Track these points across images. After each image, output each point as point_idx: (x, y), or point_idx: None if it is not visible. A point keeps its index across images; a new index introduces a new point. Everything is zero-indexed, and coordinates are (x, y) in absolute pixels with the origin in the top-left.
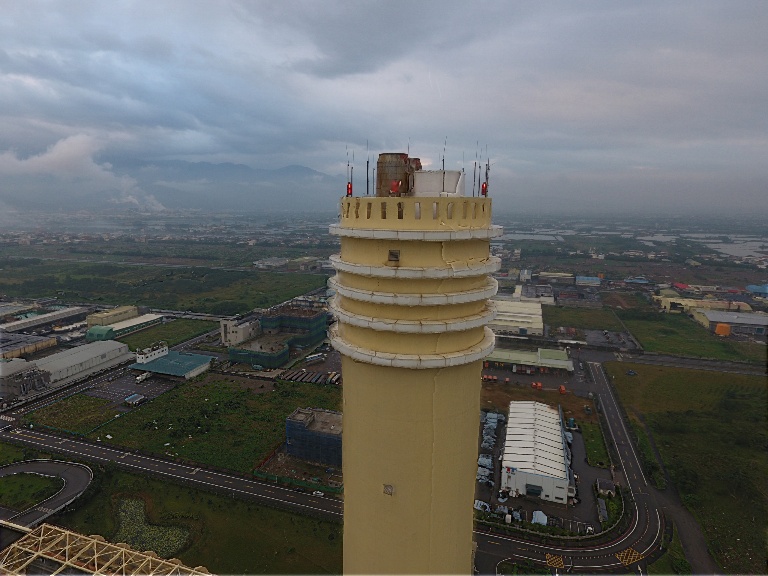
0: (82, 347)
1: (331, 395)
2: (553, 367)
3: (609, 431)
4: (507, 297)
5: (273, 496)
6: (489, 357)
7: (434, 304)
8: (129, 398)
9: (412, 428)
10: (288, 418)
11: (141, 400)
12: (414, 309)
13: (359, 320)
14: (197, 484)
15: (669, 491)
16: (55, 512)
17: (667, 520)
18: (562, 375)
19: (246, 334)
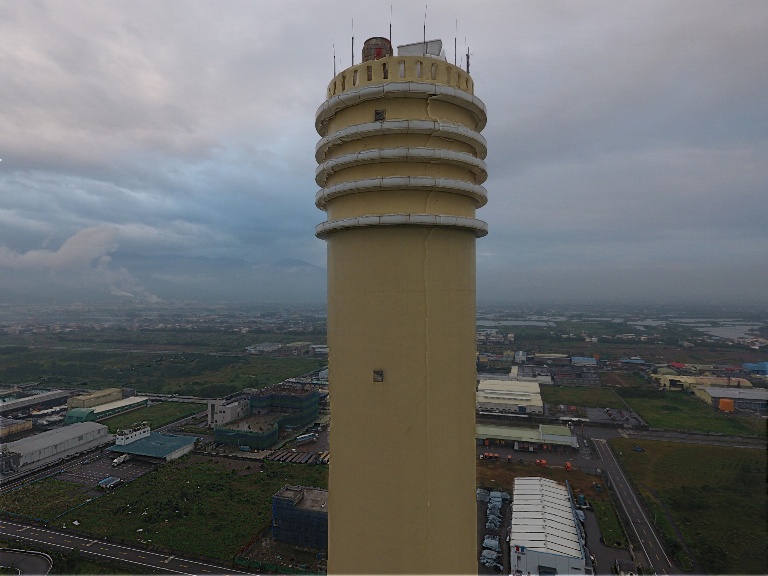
0: (59, 429)
1: (322, 475)
2: (556, 444)
3: (623, 509)
4: (503, 377)
5: None
6: (489, 434)
7: (422, 157)
8: (103, 481)
9: (403, 299)
10: (275, 495)
11: (116, 483)
12: (401, 166)
13: (346, 185)
14: (170, 574)
15: (697, 572)
16: None
17: None
18: (567, 452)
19: (234, 414)
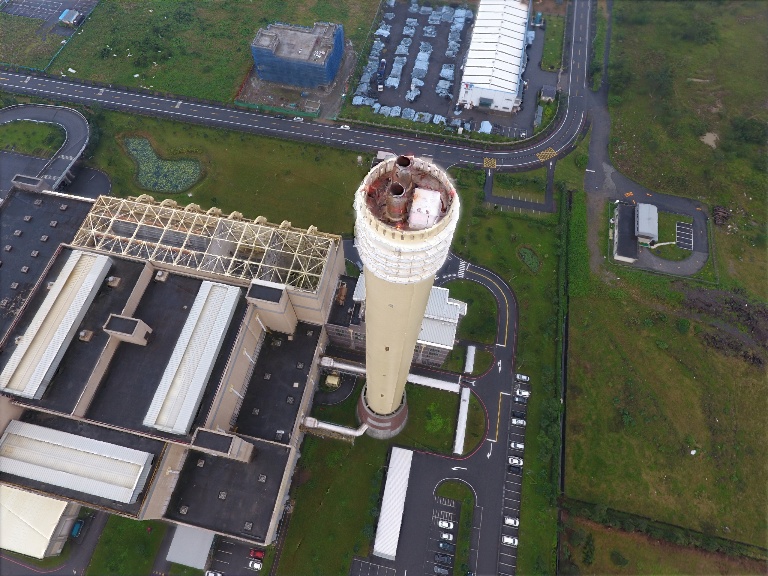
0: None
1: None
2: None
3: (572, 25)
4: None
5: (259, 125)
6: None
7: None
8: (63, 16)
9: None
10: (253, 44)
11: (78, 18)
12: None
13: (378, 266)
14: (186, 118)
15: (601, 92)
16: (77, 158)
17: (588, 121)
18: None
19: None
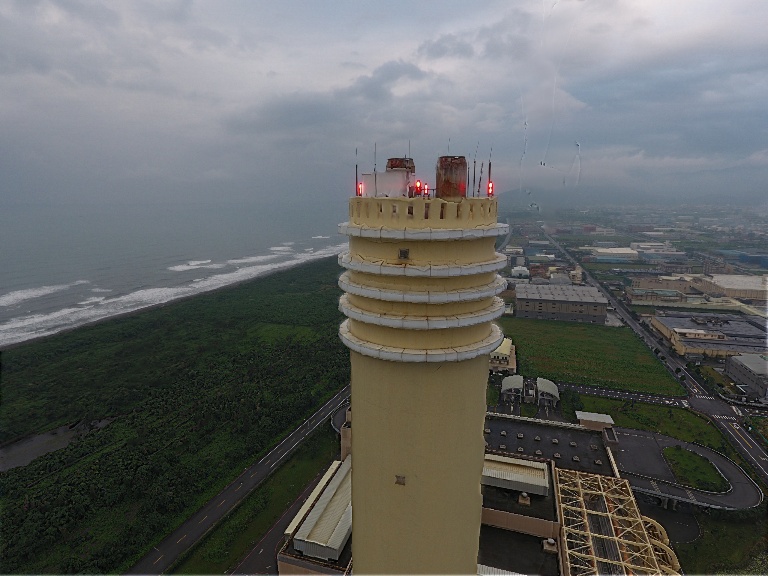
0: None
1: None
2: None
3: None
4: None
5: None
6: None
7: None
8: None
9: None
10: None
11: None
12: None
13: None
14: None
15: None
16: (697, 504)
17: None
18: None
19: None
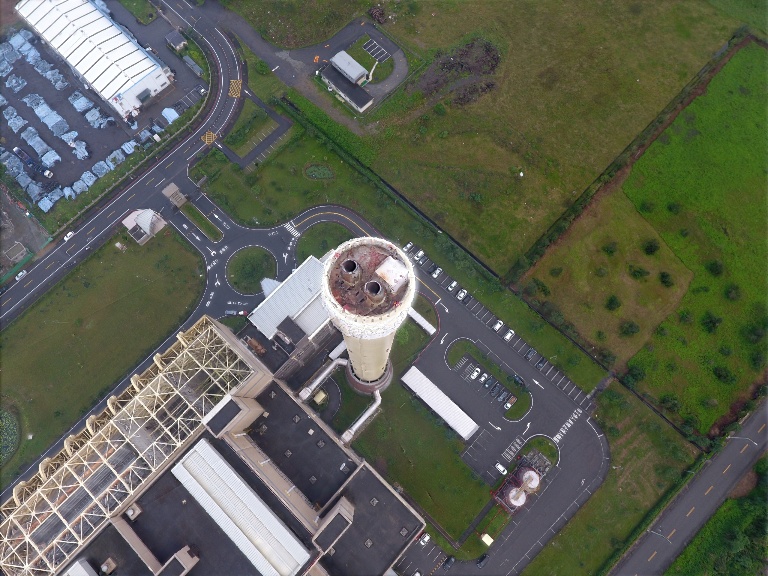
0: None
1: None
2: None
3: None
4: None
5: None
6: None
7: None
8: None
9: None
10: None
11: None
12: None
13: (387, 331)
14: None
15: (208, 1)
16: None
17: (228, 33)
18: None
19: None
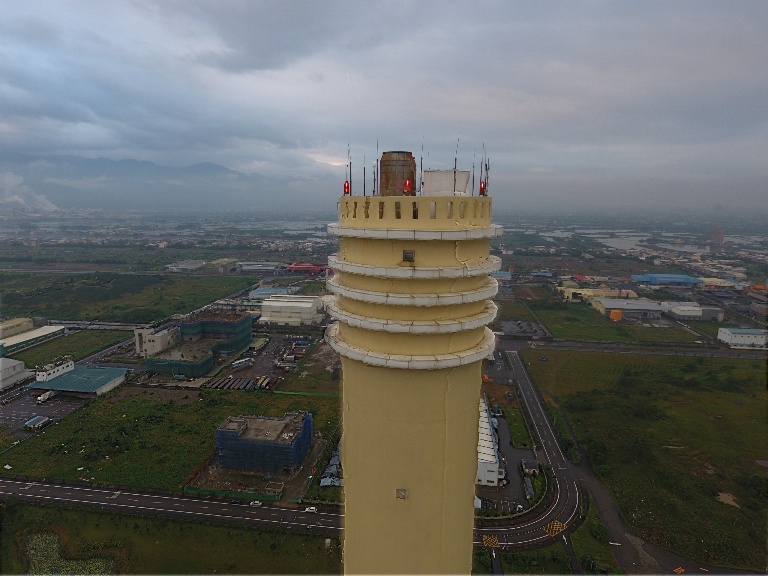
0: None
1: (262, 400)
2: None
3: (529, 414)
4: None
5: (207, 512)
6: None
7: (450, 303)
8: (30, 421)
9: (426, 429)
10: (219, 428)
11: (45, 422)
12: (429, 309)
13: (372, 323)
14: (119, 509)
15: (583, 464)
16: None
17: (584, 490)
18: (484, 365)
19: (164, 342)
